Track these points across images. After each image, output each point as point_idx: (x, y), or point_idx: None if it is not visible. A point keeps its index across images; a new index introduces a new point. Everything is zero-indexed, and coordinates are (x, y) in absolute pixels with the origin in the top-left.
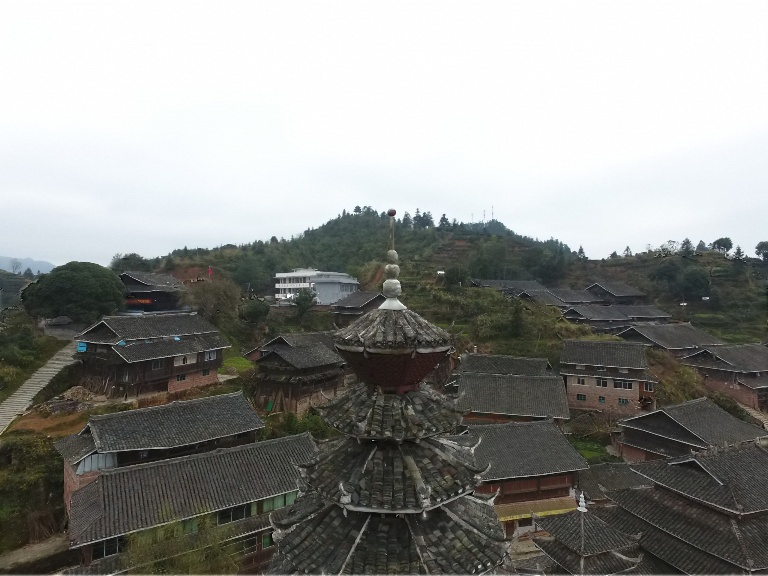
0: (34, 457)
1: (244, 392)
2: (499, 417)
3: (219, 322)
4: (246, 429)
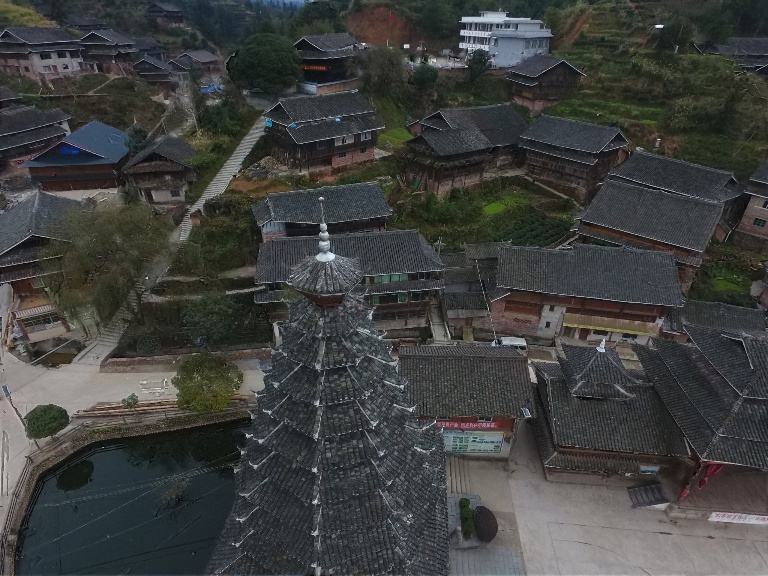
0: (243, 212)
1: (395, 169)
2: (626, 234)
3: (389, 88)
4: (376, 215)
